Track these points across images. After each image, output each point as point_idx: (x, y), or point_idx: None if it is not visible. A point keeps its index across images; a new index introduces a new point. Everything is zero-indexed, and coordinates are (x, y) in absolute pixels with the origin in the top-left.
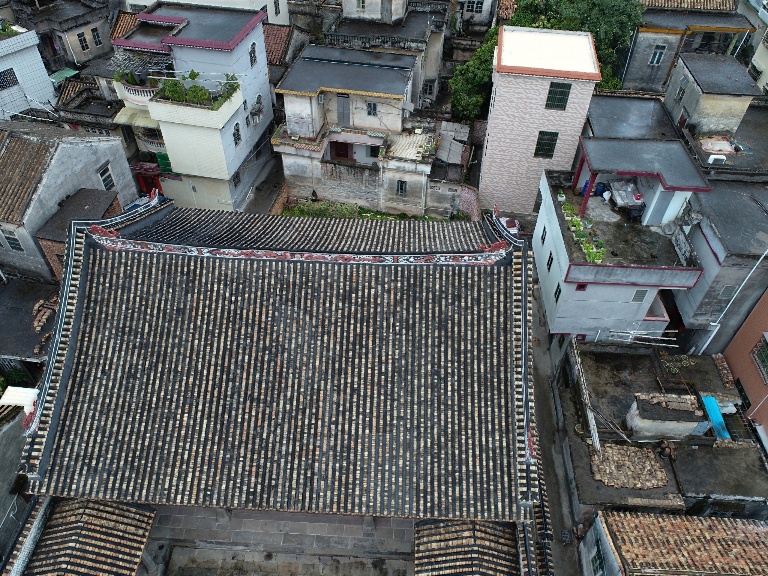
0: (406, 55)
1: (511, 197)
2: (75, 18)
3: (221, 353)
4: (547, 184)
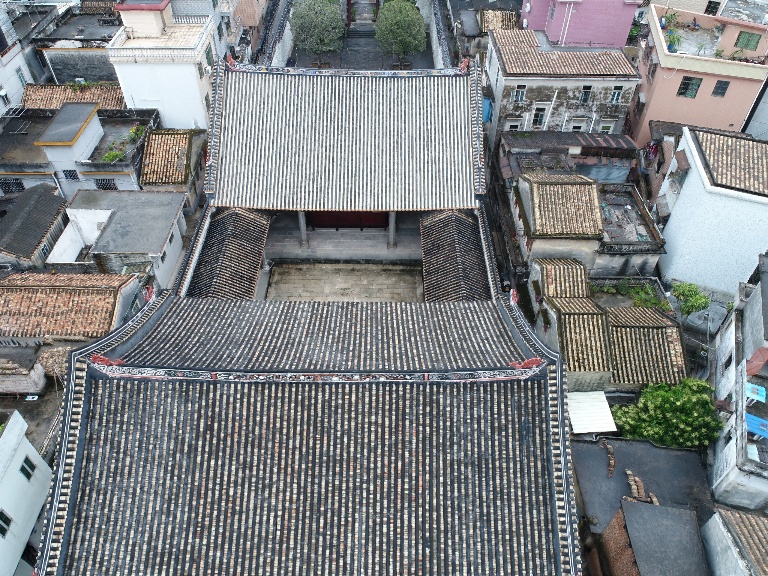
0: None
1: None
2: None
3: (391, 348)
4: None
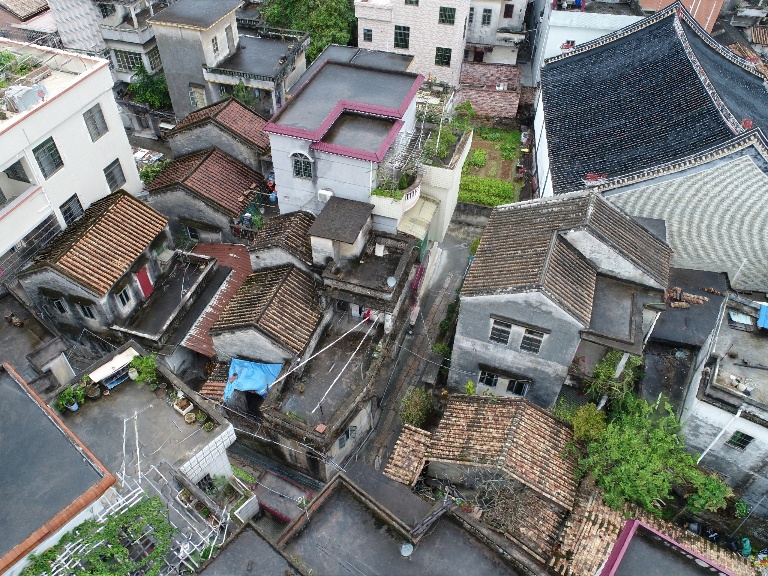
0: (326, 49)
1: (456, 83)
2: (42, 321)
3: None
4: (569, 12)
